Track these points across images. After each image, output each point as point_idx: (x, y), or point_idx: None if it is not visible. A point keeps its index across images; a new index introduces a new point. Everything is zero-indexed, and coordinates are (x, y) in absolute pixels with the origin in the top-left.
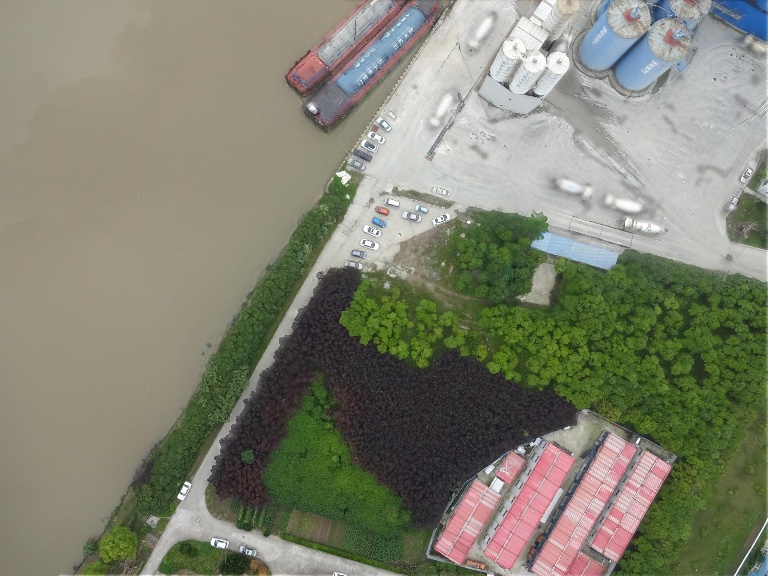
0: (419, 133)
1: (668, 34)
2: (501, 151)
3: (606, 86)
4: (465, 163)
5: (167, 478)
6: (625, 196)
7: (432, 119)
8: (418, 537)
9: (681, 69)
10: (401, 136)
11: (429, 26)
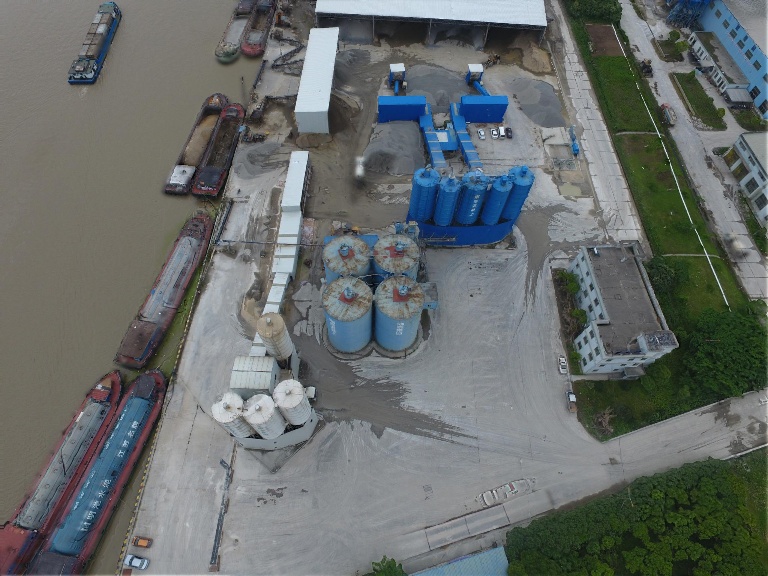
0: (189, 542)
1: (395, 293)
2: (301, 500)
3: (377, 359)
4: (264, 545)
5: None
6: (466, 463)
7: (200, 513)
8: None
9: (434, 308)
10: (166, 562)
11: (158, 406)
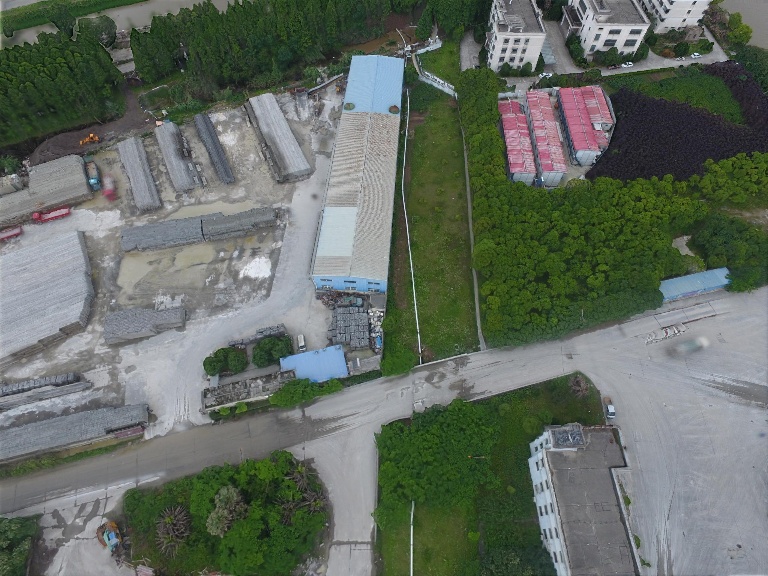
0: None
1: None
2: None
3: None
4: None
5: (761, 58)
6: (696, 358)
7: None
8: (608, 95)
9: None
10: None
11: None
